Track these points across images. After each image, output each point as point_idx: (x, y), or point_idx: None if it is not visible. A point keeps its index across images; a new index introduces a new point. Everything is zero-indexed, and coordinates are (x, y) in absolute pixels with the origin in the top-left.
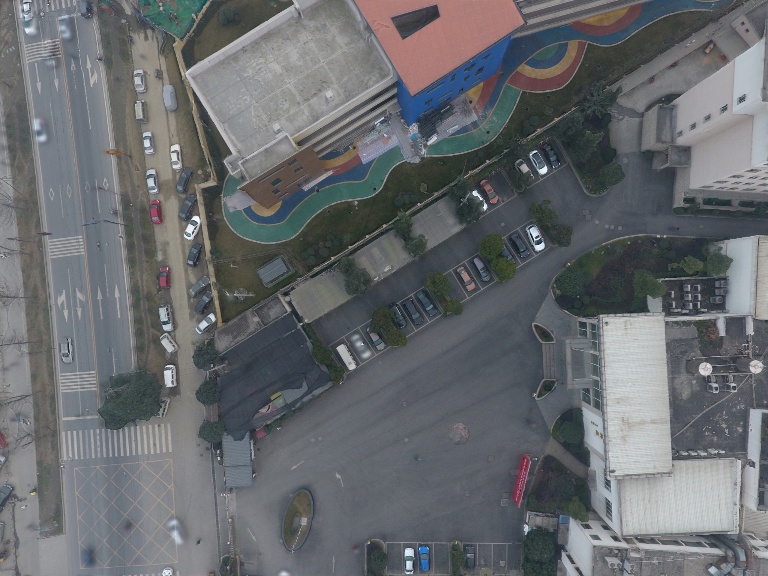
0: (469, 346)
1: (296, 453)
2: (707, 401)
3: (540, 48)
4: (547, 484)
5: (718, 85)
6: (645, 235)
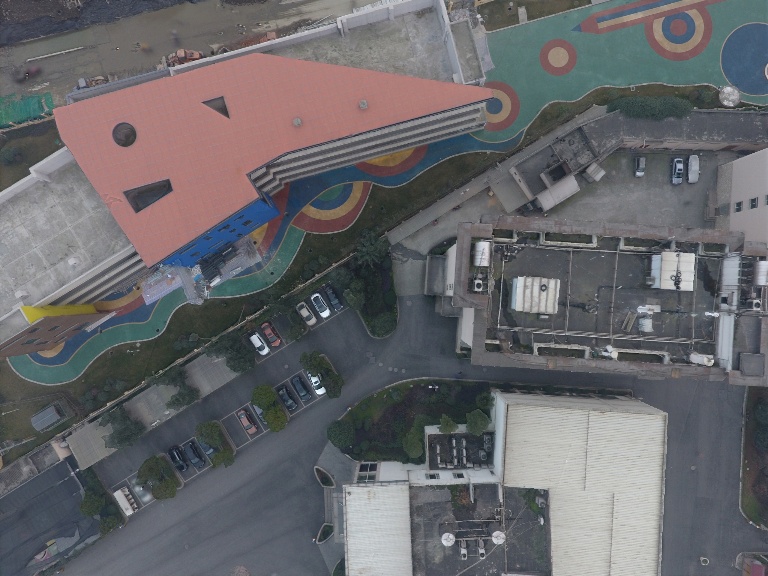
0: (251, 489)
1: None
2: (460, 565)
3: (325, 189)
4: None
5: None
6: (428, 378)
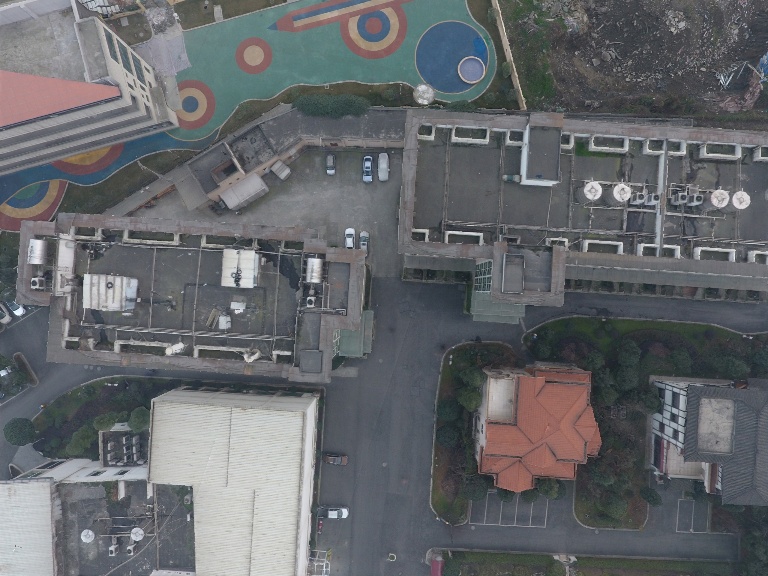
0: None
1: None
2: (113, 561)
3: (21, 187)
4: None
5: None
6: (123, 376)
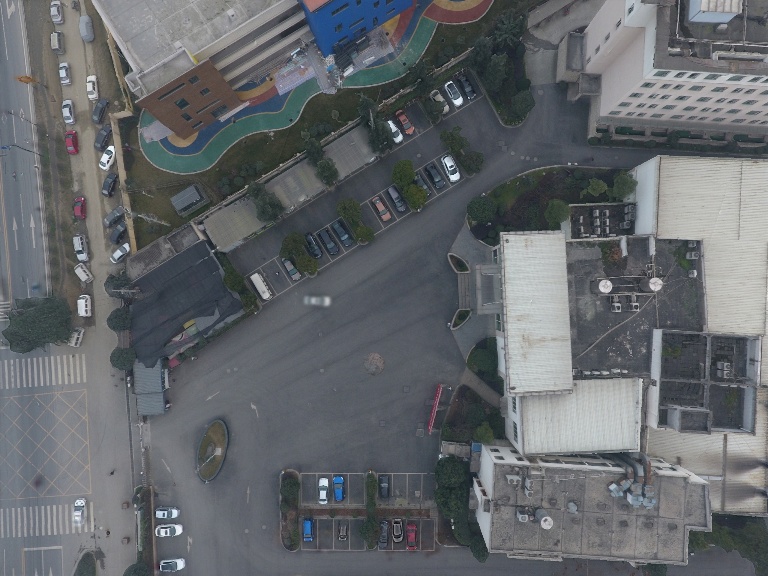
0: (385, 277)
1: (211, 384)
2: (611, 322)
3: None
4: (460, 413)
5: (615, 2)
6: (560, 166)
